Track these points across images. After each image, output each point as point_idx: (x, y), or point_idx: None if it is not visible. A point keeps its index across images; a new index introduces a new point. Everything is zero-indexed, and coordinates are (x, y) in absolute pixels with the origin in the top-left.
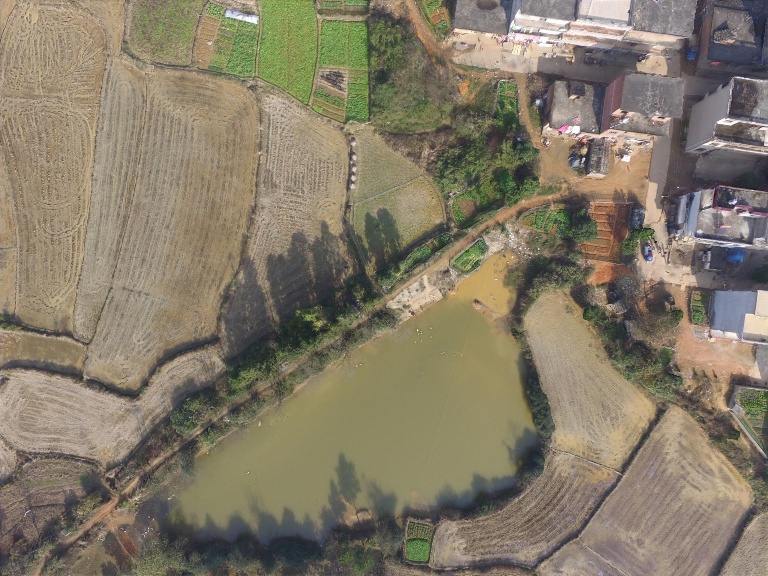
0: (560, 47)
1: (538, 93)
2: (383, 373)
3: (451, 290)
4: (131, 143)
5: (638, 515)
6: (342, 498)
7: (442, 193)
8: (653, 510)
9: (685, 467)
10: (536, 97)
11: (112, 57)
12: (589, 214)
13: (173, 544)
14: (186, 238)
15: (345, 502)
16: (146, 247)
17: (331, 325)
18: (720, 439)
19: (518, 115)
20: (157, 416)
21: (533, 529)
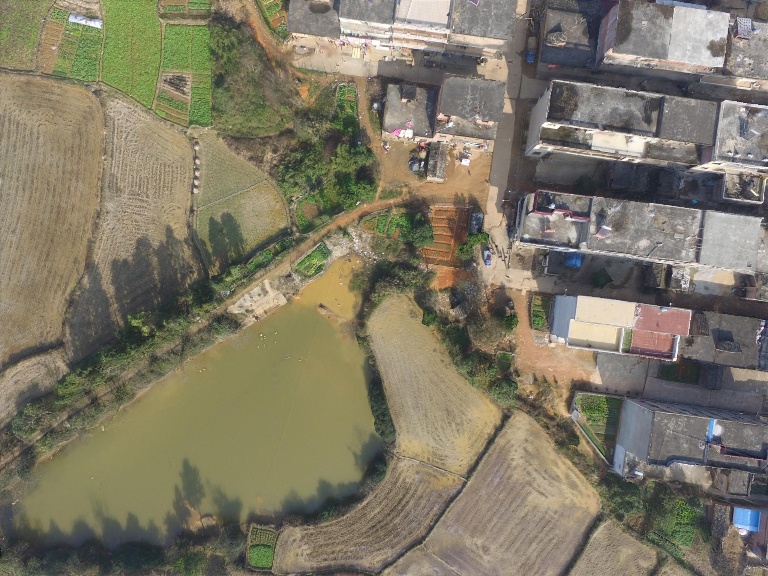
0: (397, 50)
1: (378, 97)
2: (226, 378)
3: (295, 295)
4: None
5: (483, 521)
6: (186, 503)
7: (285, 197)
8: (499, 516)
9: (531, 473)
10: (375, 101)
11: None
12: (429, 218)
13: (11, 549)
14: (32, 243)
15: (189, 507)
16: None
17: (156, 330)
18: (563, 445)
19: (358, 119)
20: (2, 421)
21: (377, 535)
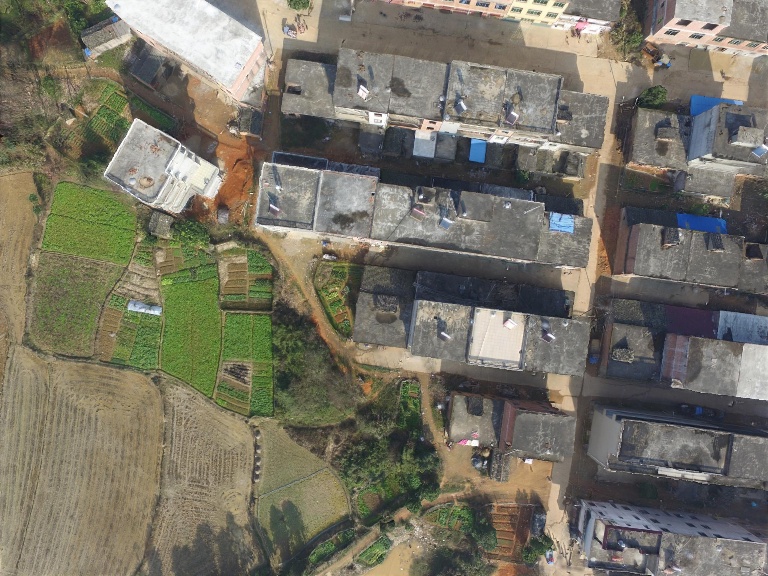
0: None
1: (441, 394)
2: None
3: None
4: (34, 432)
5: None
6: None
7: (346, 488)
8: None
9: None
10: (439, 399)
11: (14, 345)
12: (491, 515)
13: None
14: (90, 528)
15: None
16: (50, 537)
17: None
18: None
19: (421, 414)
20: None
21: None
